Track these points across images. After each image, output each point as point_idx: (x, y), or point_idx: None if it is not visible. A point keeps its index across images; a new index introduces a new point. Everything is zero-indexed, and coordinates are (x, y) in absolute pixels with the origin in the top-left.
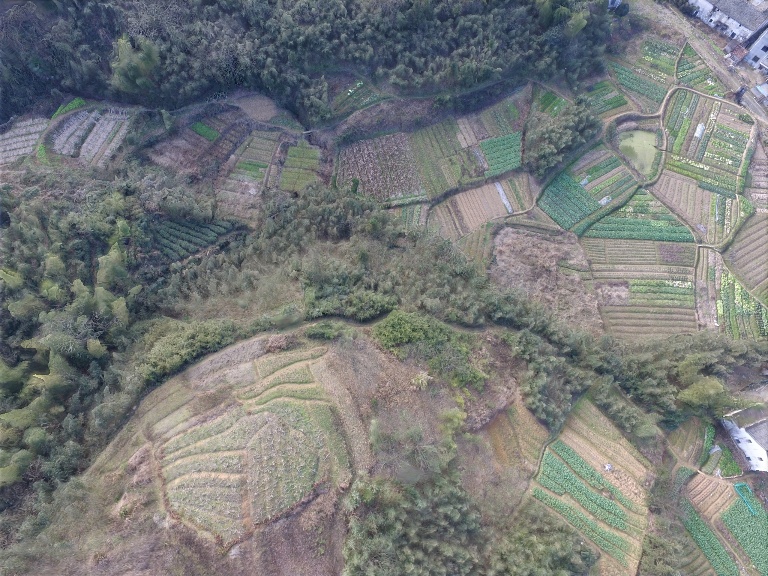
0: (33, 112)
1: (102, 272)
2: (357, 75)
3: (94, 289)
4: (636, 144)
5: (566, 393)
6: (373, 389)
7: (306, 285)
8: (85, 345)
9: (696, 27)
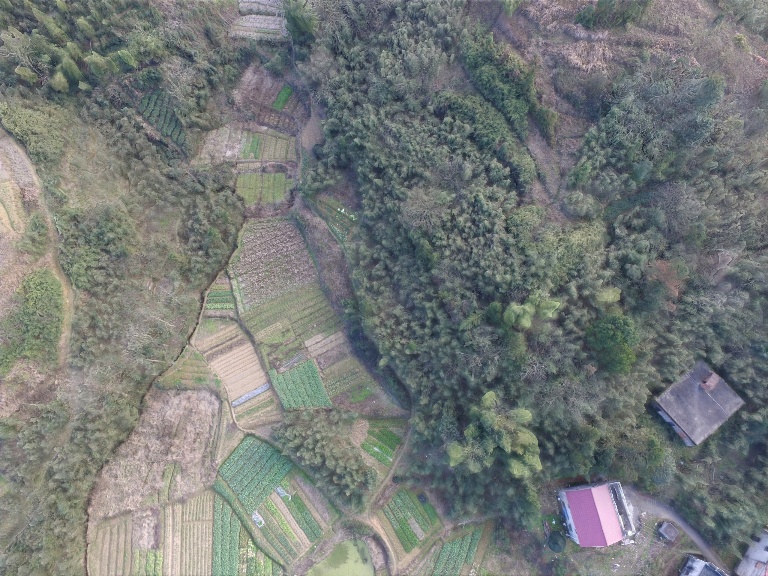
0: None
1: (86, 58)
2: None
3: None
4: (352, 567)
5: (3, 463)
6: None
7: None
8: None
9: None
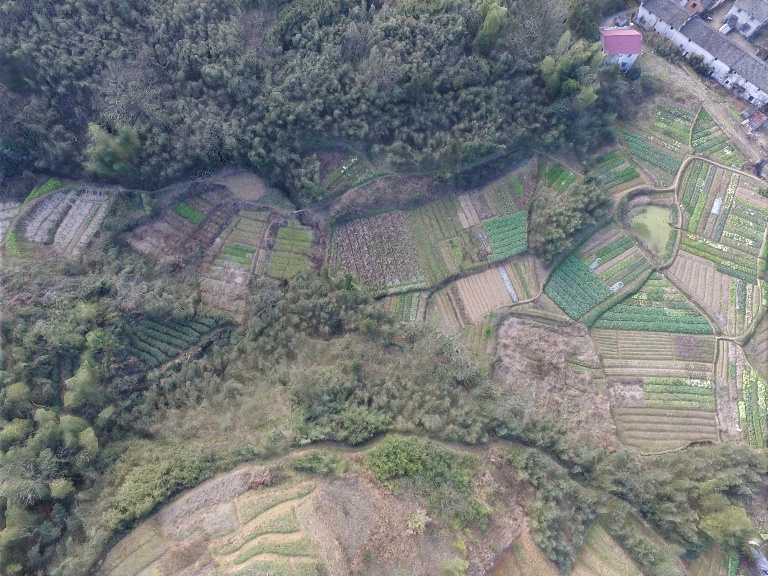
0: (4, 196)
1: (69, 396)
2: (351, 150)
3: (62, 410)
4: (649, 221)
5: (577, 523)
6: (365, 537)
7: (293, 402)
8: (47, 486)
9: (711, 89)
